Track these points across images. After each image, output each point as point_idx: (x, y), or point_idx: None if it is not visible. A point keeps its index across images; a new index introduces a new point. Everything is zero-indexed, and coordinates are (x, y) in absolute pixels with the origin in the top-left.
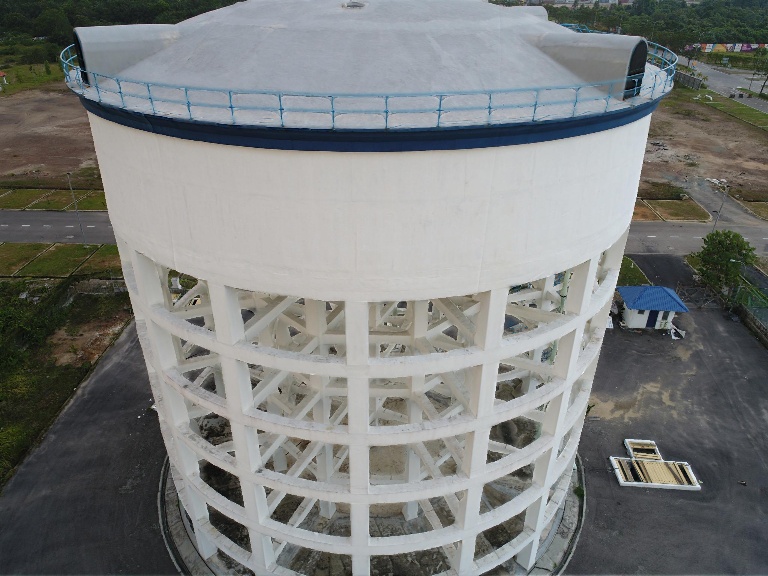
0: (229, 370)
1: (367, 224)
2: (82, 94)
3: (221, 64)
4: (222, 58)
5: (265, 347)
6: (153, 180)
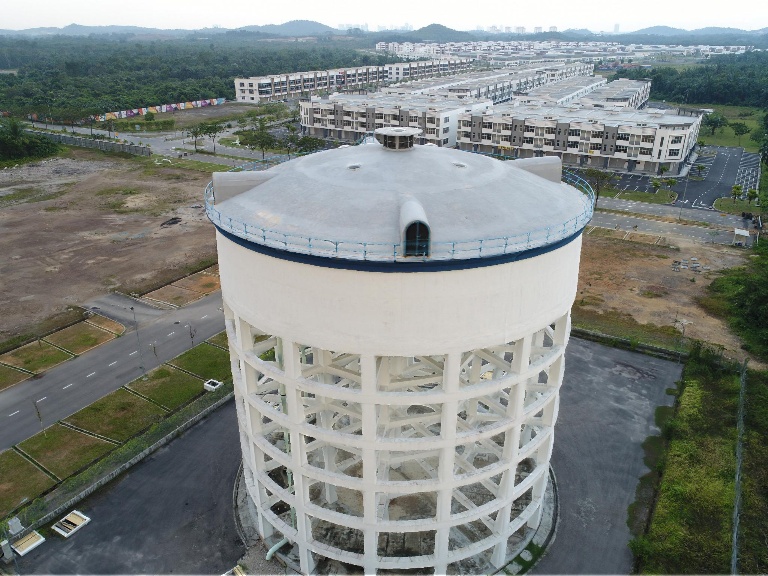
0: (522, 390)
1: (575, 266)
2: (452, 259)
3: (494, 215)
4: (487, 212)
5: (535, 362)
6: (500, 292)
